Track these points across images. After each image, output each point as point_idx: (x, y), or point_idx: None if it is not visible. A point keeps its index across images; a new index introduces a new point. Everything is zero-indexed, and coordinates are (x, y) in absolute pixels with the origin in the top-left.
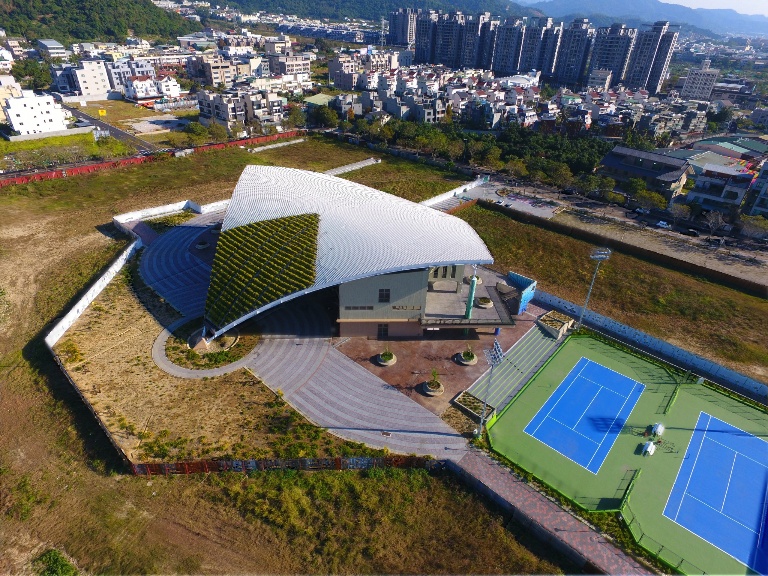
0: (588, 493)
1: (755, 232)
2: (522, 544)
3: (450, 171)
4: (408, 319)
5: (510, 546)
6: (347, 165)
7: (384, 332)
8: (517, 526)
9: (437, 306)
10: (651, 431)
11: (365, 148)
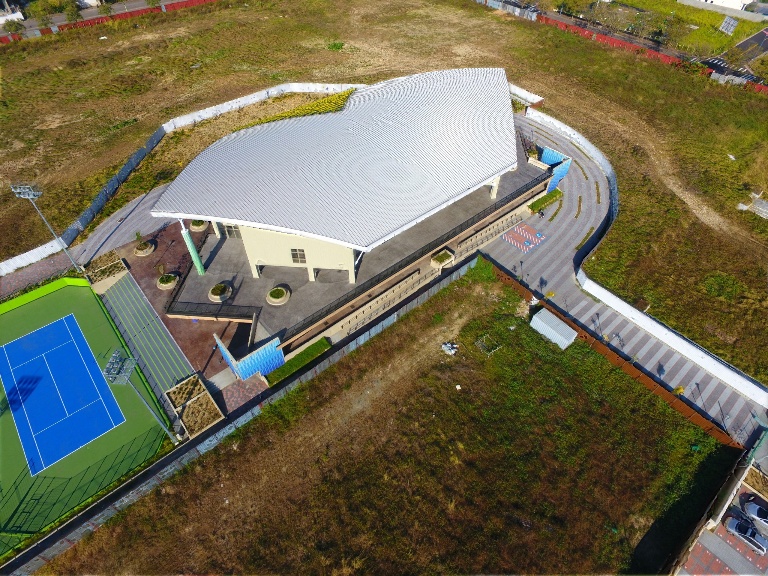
0: None
1: None
2: None
3: None
4: None
5: None
6: None
7: None
8: None
9: (235, 251)
10: None
11: None
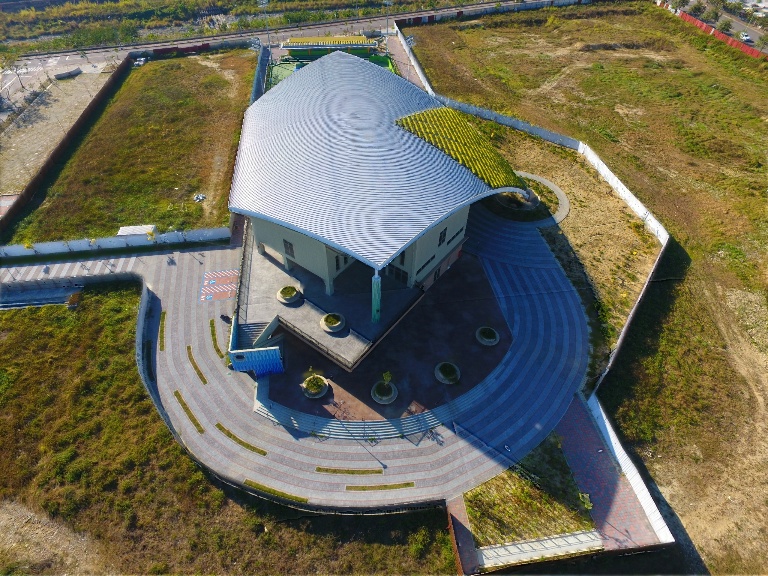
0: None
1: None
2: None
3: None
4: None
5: None
6: None
7: None
8: None
9: None
10: None
11: None
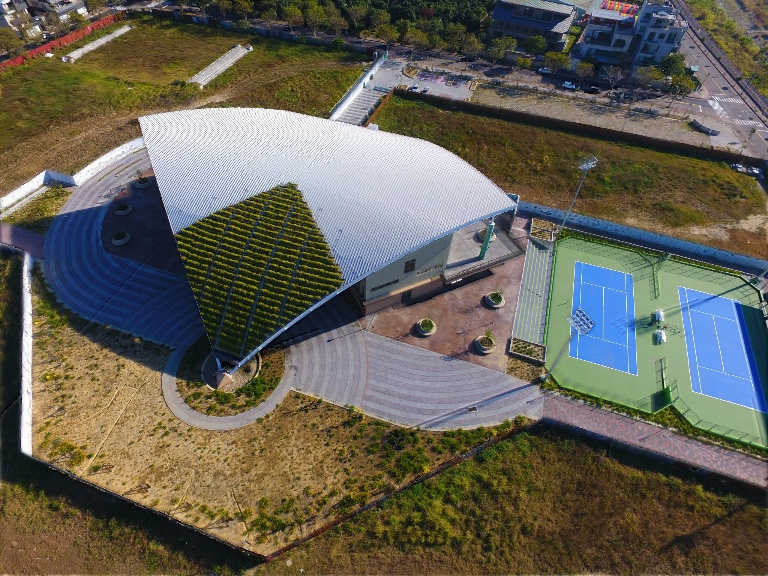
0: (640, 395)
1: (640, 79)
2: (626, 465)
3: (340, 50)
4: (431, 278)
5: (620, 472)
6: (215, 62)
7: (407, 297)
8: (616, 451)
9: None
10: (656, 319)
11: (220, 29)
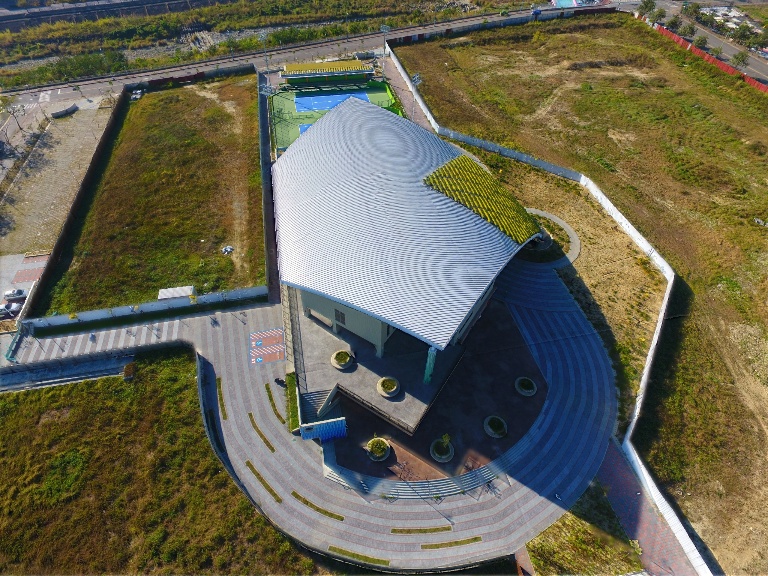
0: None
1: None
2: None
3: None
4: None
5: None
6: None
7: None
8: None
9: None
10: None
11: None
